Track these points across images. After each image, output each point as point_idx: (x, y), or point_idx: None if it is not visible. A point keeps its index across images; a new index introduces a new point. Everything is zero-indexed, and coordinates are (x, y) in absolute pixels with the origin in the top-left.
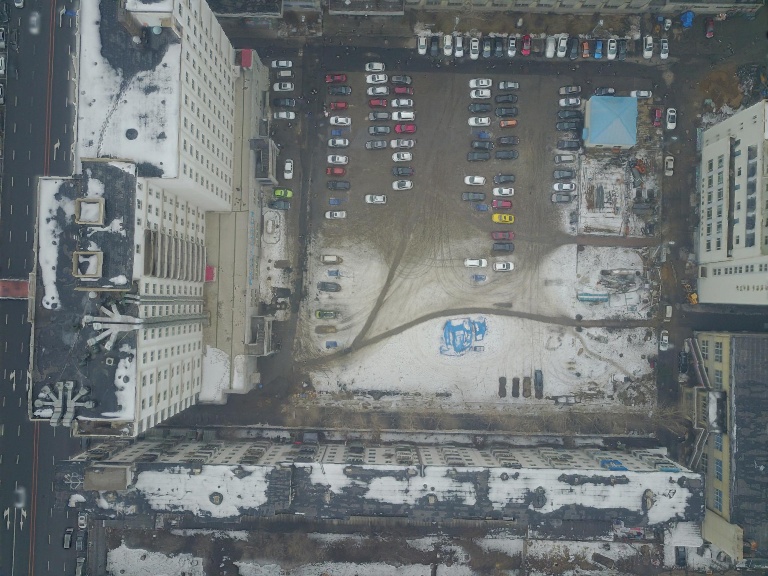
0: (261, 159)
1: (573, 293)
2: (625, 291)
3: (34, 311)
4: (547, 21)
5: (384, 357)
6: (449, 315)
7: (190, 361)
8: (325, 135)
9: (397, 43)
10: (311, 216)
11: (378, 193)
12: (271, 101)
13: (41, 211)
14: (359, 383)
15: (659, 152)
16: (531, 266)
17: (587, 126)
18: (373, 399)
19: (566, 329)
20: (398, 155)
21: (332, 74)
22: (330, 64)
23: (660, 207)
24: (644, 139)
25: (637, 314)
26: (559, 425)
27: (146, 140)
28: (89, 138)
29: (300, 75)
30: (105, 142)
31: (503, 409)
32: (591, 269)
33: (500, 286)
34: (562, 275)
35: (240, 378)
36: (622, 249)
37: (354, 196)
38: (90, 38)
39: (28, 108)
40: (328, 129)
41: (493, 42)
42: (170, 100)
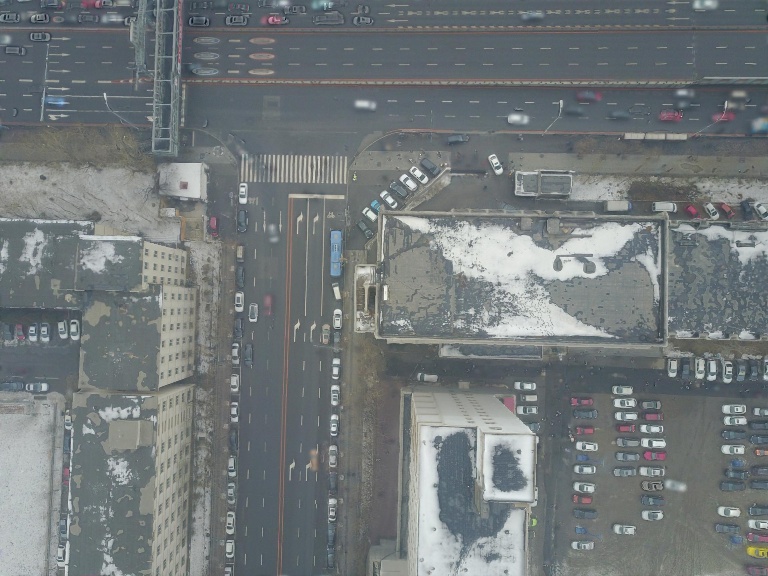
0: None
1: None
2: None
3: None
4: None
5: None
6: None
7: None
8: (570, 459)
9: (644, 363)
10: (556, 544)
11: (626, 522)
12: None
13: None
14: None
15: None
16: None
17: None
18: None
19: None
20: (649, 485)
21: (578, 397)
22: (574, 384)
23: None
24: None
25: None
26: None
27: None
28: None
29: (543, 395)
30: None
31: None
32: None
33: None
34: None
35: None
36: None
37: (601, 524)
38: (428, 502)
39: (262, 426)
40: (573, 453)
41: (746, 364)
42: (513, 570)
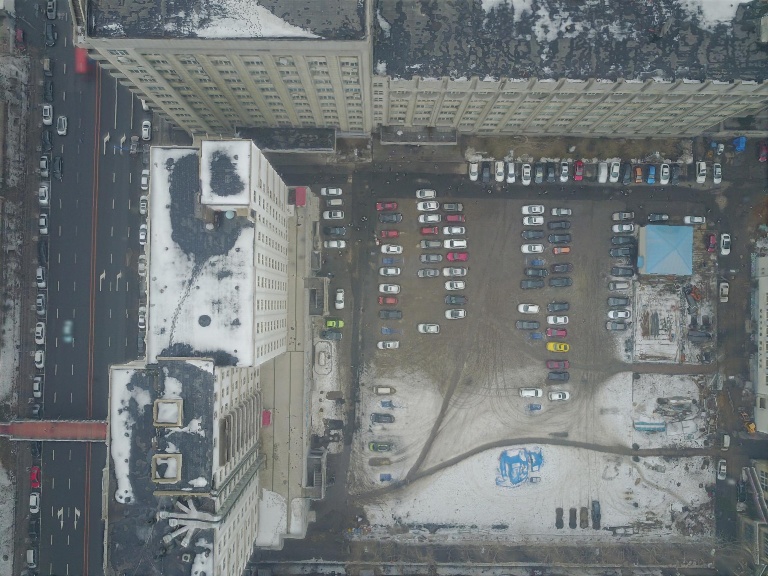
0: (315, 297)
1: (629, 422)
2: (682, 419)
3: (107, 506)
4: (599, 145)
5: (439, 489)
6: (504, 445)
7: (250, 514)
8: (376, 263)
9: (448, 169)
10: (363, 346)
11: (431, 322)
12: (321, 229)
13: (113, 402)
14: (414, 516)
15: (713, 278)
16: (586, 395)
17: (642, 254)
18: (429, 532)
19: (623, 458)
20: (451, 284)
21: (383, 201)
22: (380, 190)
23: (715, 333)
24: (698, 265)
25: (694, 442)
26: (617, 556)
27: (219, 327)
28: (161, 325)
29: (350, 202)
30: (177, 329)
31: (560, 541)
32: (647, 397)
33: (555, 415)
34: (618, 403)
35: (297, 522)
36: (678, 377)
37: (406, 325)
38: (160, 222)
39: (72, 238)
40: (379, 257)
41: (545, 167)
42: (244, 286)
